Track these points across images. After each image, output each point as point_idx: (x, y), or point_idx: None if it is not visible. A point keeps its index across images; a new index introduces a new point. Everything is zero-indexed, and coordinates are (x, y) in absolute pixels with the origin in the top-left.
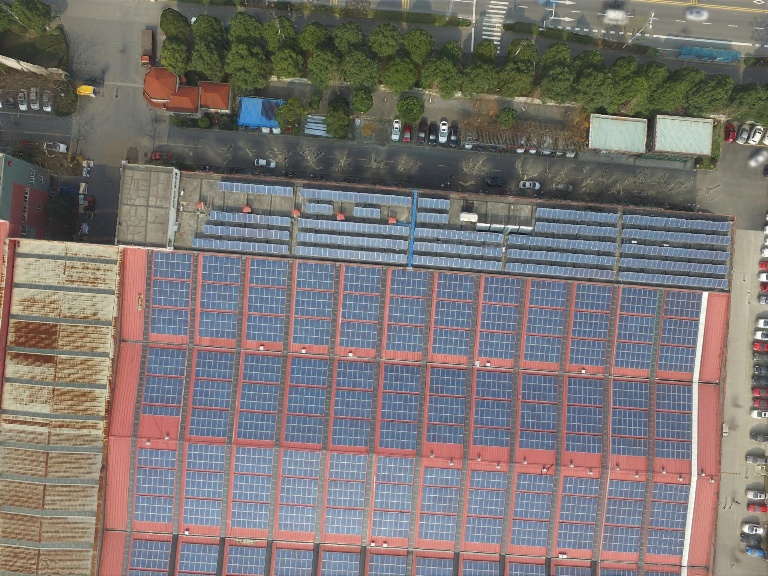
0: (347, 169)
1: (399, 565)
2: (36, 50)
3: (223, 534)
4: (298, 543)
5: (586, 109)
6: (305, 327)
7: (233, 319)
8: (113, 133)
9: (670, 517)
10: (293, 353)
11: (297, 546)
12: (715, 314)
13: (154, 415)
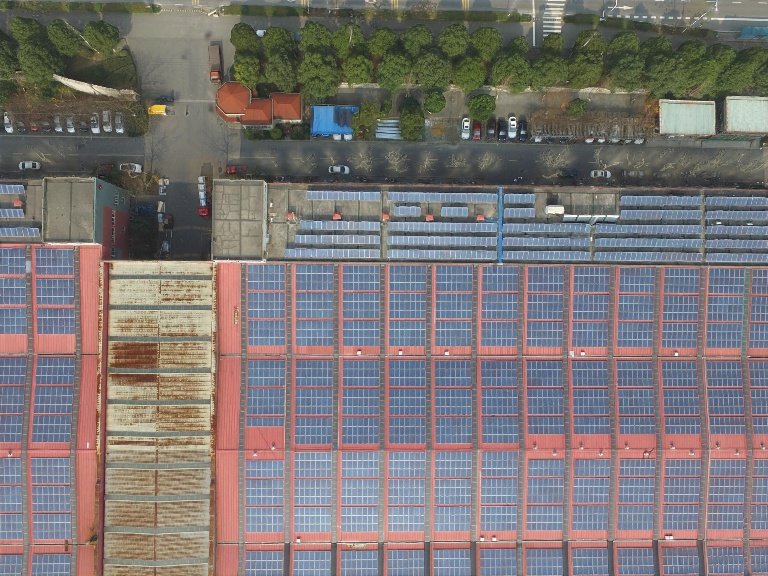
0: None
1: (509, 558)
2: (105, 73)
3: (334, 539)
4: (409, 543)
5: (655, 95)
6: (400, 329)
7: (329, 326)
8: (186, 150)
9: None
10: (390, 356)
11: (408, 546)
12: None
13: (259, 426)
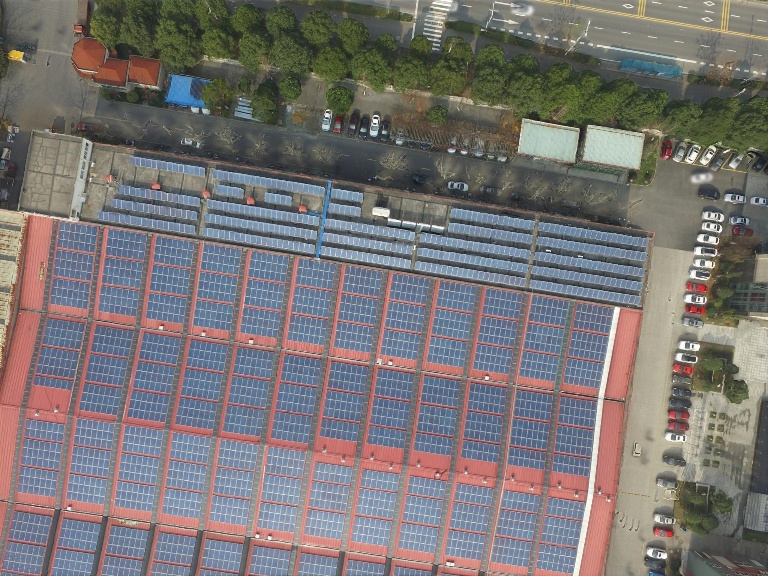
0: (275, 155)
1: (282, 559)
2: None
3: (106, 513)
4: (181, 528)
5: (517, 113)
6: (207, 310)
7: (134, 296)
8: (41, 101)
9: (563, 533)
10: (193, 335)
11: (180, 531)
12: (626, 330)
13: (45, 387)
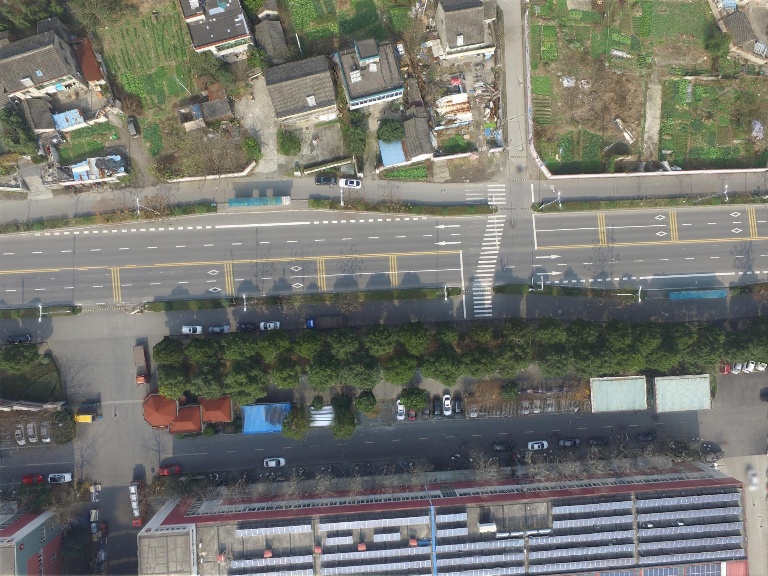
0: (356, 454)
1: None
2: (27, 382)
3: None
4: None
5: None
6: None
7: None
8: (117, 453)
9: None
10: None
11: None
12: None
13: None
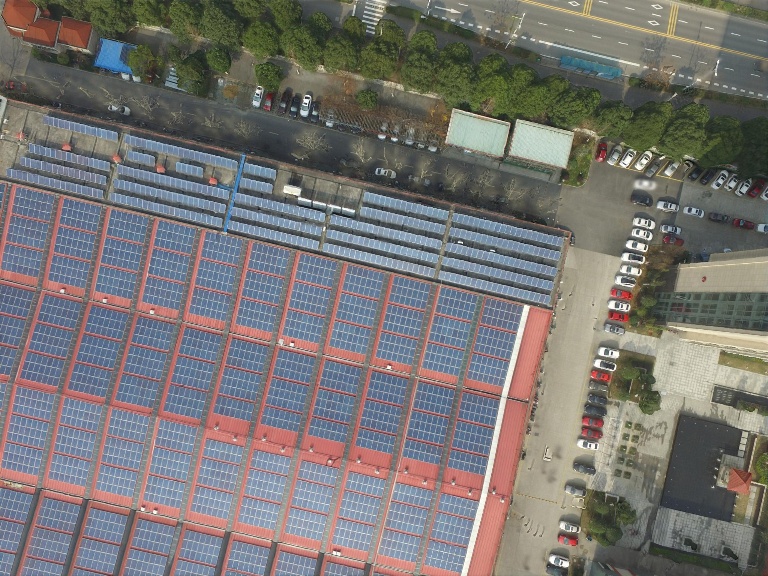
0: (203, 128)
1: (166, 535)
2: None
3: None
4: (67, 495)
5: (447, 102)
6: (110, 277)
7: (38, 257)
8: None
9: (454, 531)
10: (94, 301)
11: (65, 498)
12: (534, 330)
13: None
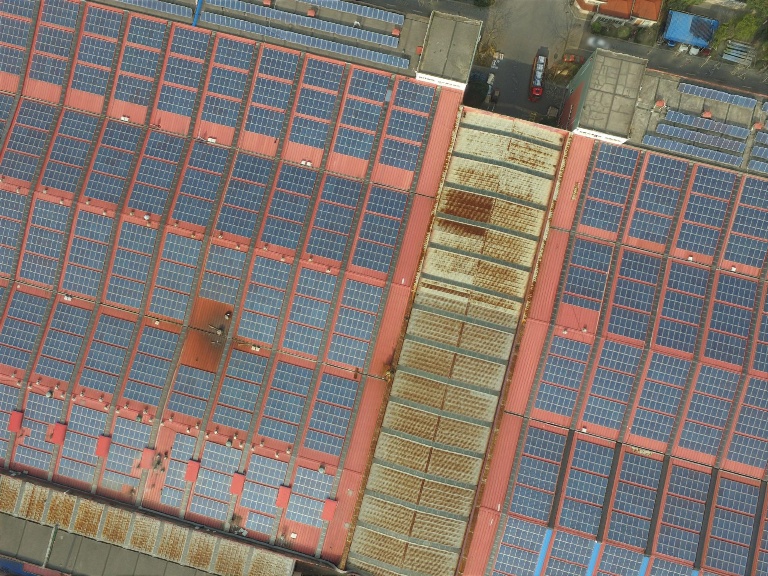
0: None
1: None
2: None
3: (620, 439)
4: (696, 464)
5: None
6: (740, 245)
7: (667, 224)
8: (527, 30)
9: None
10: (721, 269)
11: (694, 467)
12: None
13: (574, 305)
